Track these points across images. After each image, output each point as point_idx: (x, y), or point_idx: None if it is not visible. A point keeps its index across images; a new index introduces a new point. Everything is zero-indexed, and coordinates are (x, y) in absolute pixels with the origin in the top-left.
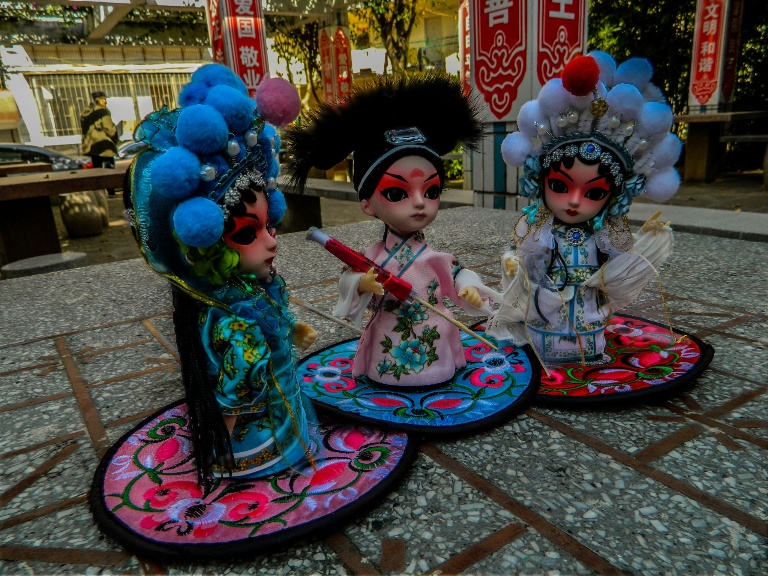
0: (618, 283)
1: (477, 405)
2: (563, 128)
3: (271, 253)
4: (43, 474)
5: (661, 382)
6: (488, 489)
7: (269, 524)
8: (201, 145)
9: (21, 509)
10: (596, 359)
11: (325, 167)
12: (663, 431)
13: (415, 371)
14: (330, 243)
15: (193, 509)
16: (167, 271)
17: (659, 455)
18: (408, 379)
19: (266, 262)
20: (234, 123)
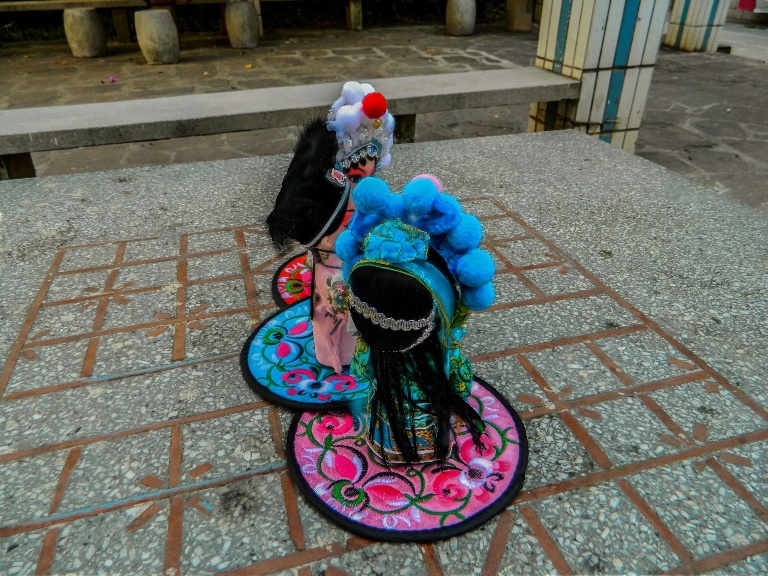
0: None
1: None
2: None
3: None
4: None
5: None
6: (488, 357)
7: (508, 435)
8: None
9: None
10: None
11: None
12: None
13: None
14: None
15: (474, 474)
16: None
17: None
18: None
19: None
20: None
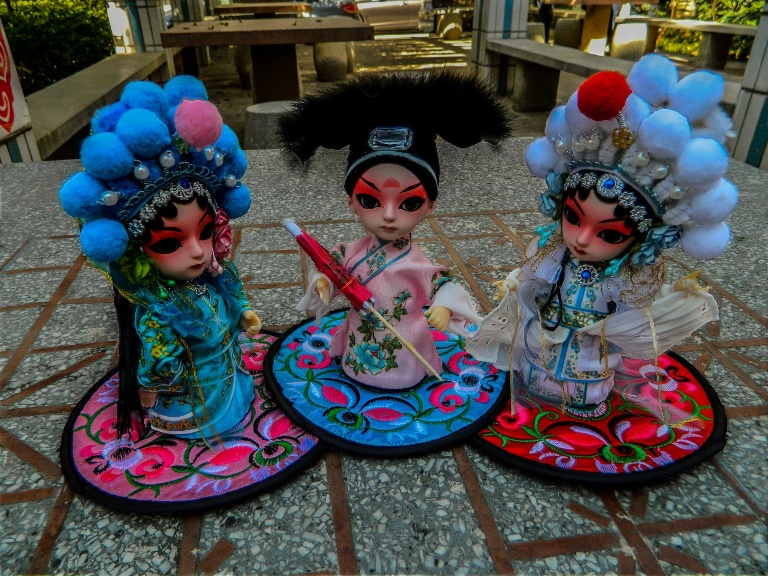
0: (626, 339)
1: (409, 427)
2: (582, 152)
3: (196, 261)
4: (66, 375)
5: (610, 471)
6: (341, 525)
7: (148, 491)
8: (100, 174)
9: (35, 403)
10: (585, 408)
11: (334, 147)
12: (569, 528)
13: (372, 372)
14: (300, 238)
15: (121, 451)
16: (101, 266)
17: (534, 556)
18: (365, 377)
19: (192, 268)
20: (139, 151)
